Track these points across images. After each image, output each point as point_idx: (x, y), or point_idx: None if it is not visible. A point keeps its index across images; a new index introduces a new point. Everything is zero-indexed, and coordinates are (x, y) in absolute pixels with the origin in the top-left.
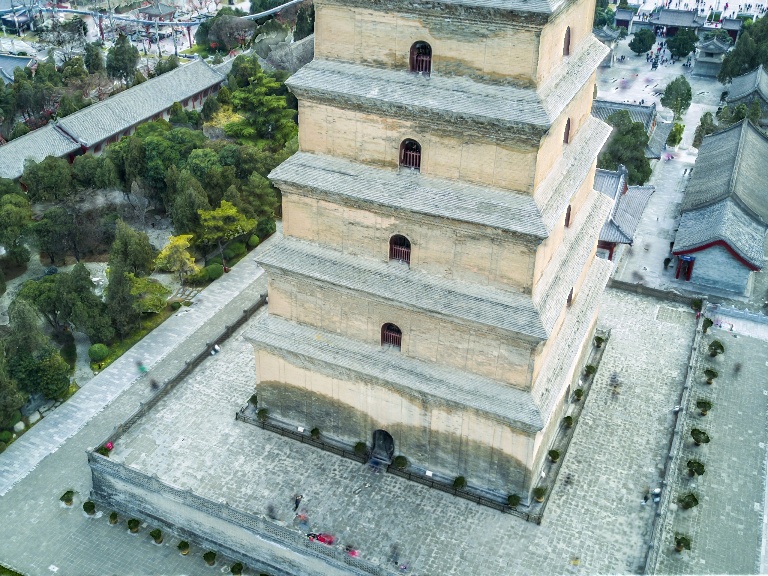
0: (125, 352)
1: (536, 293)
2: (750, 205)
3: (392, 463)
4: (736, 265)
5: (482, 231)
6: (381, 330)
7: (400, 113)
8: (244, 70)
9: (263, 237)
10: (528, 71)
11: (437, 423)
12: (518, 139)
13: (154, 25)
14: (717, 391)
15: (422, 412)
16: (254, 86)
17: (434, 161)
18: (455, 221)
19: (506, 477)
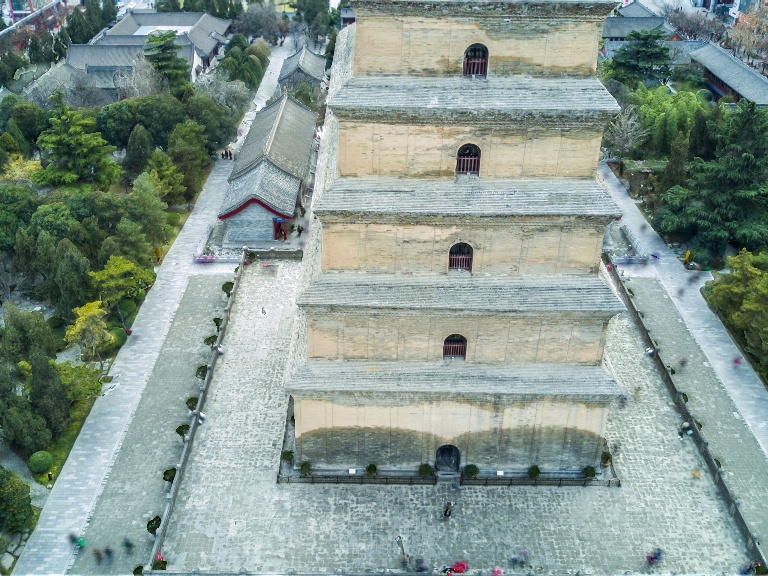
0: (69, 453)
1: None
2: None
3: (462, 475)
4: None
5: (553, 222)
6: (443, 344)
7: (461, 119)
8: (21, 111)
9: (147, 288)
10: (589, 61)
11: (509, 421)
12: (583, 127)
13: None
14: None
15: (493, 414)
16: (65, 126)
17: (495, 162)
18: (527, 217)
19: (579, 452)
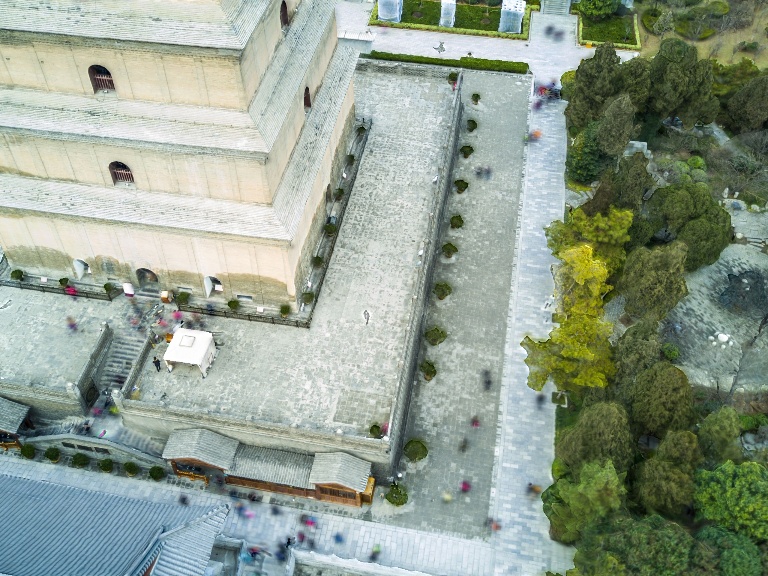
0: None
1: None
2: None
3: None
4: None
5: None
6: None
7: None
8: None
9: None
10: None
11: None
12: None
13: None
14: None
15: None
16: None
17: None
18: None
19: None
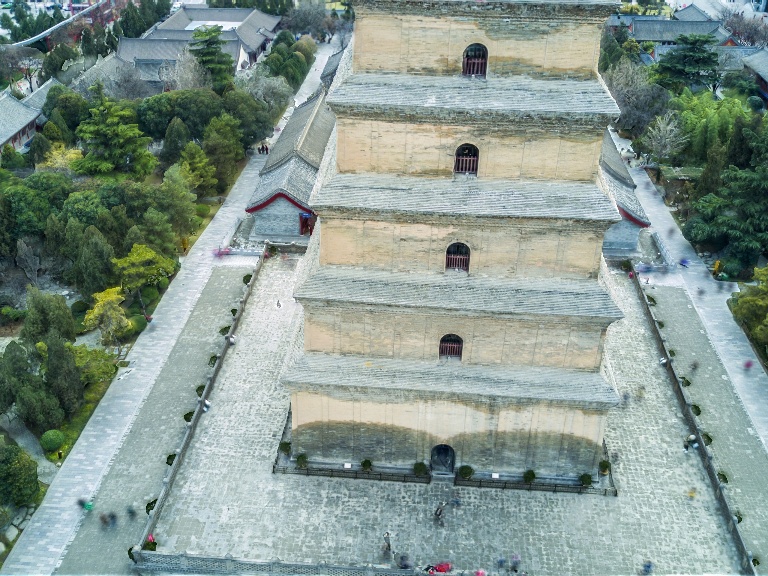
0: (81, 433)
1: None
2: (615, 170)
3: (456, 475)
4: (628, 225)
5: (551, 225)
6: (439, 343)
7: (458, 119)
8: (65, 101)
9: (171, 277)
10: (590, 63)
11: (504, 424)
12: (583, 130)
13: None
14: (666, 339)
15: (488, 416)
16: (103, 117)
17: (493, 163)
18: (524, 219)
19: (576, 459)
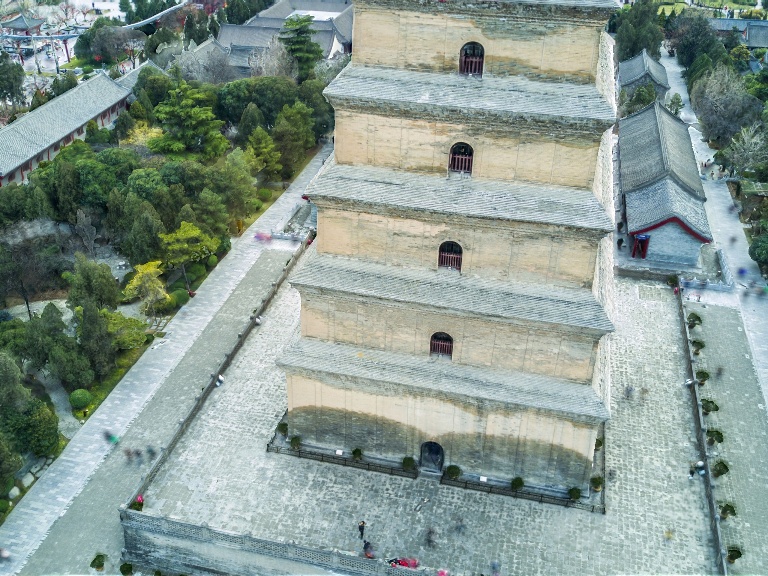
0: (108, 395)
1: (592, 286)
2: (685, 181)
3: (444, 474)
4: (688, 239)
5: (543, 230)
6: (430, 340)
7: (452, 117)
8: (153, 82)
9: (220, 256)
10: (588, 67)
11: (493, 427)
12: (579, 135)
13: (25, 40)
14: (706, 360)
15: (477, 418)
16: (179, 98)
17: (487, 163)
18: (515, 222)
19: (565, 472)
